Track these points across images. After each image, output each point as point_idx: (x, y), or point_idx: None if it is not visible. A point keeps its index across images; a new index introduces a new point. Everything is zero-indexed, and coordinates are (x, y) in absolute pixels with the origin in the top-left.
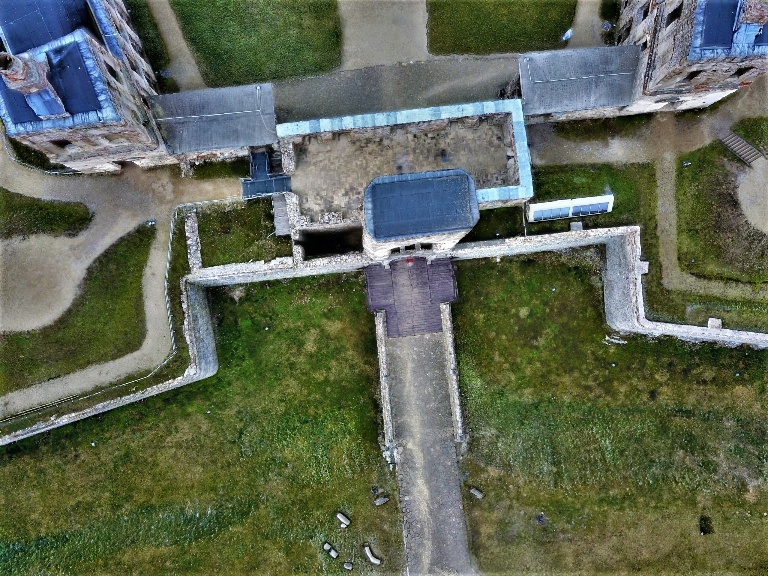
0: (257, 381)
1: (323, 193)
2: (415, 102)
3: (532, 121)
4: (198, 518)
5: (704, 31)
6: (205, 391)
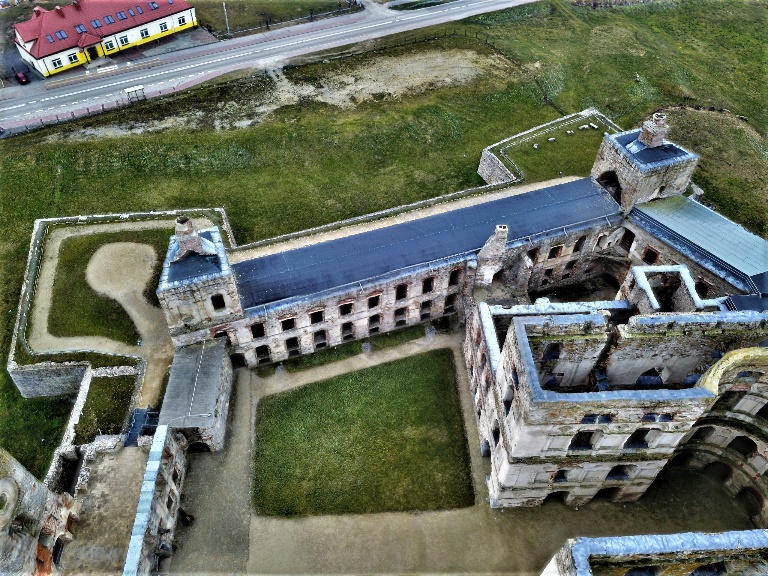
0: (2, 430)
1: (112, 474)
2: None
3: None
4: None
5: None
6: (11, 387)
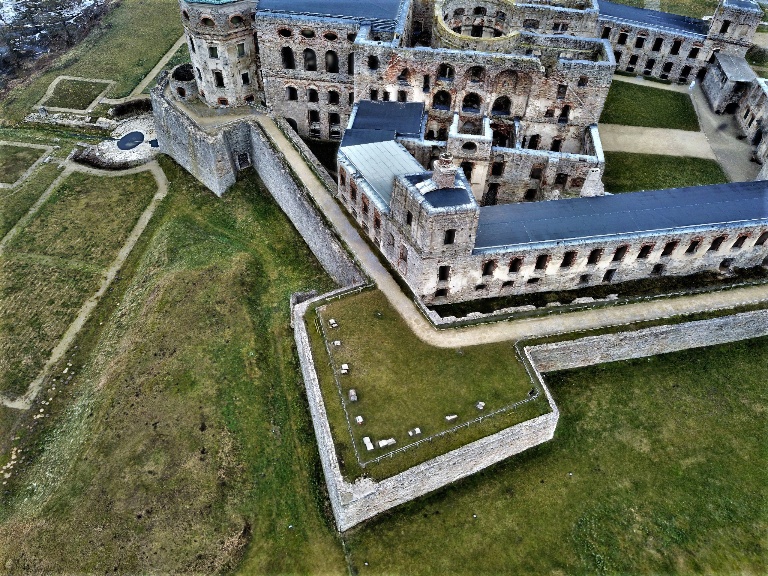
0: None
1: None
2: (730, 139)
3: None
4: None
5: (752, 8)
6: None
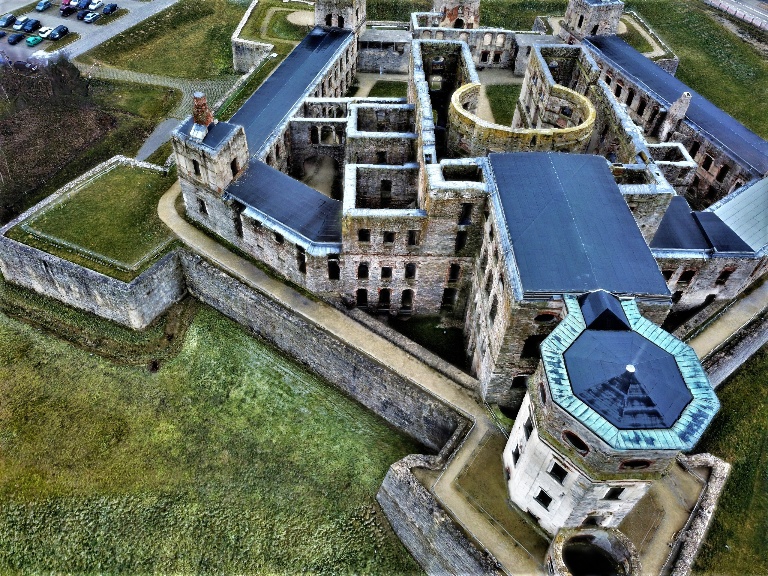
0: None
1: None
2: None
3: (402, 48)
4: (531, 7)
5: None
6: None
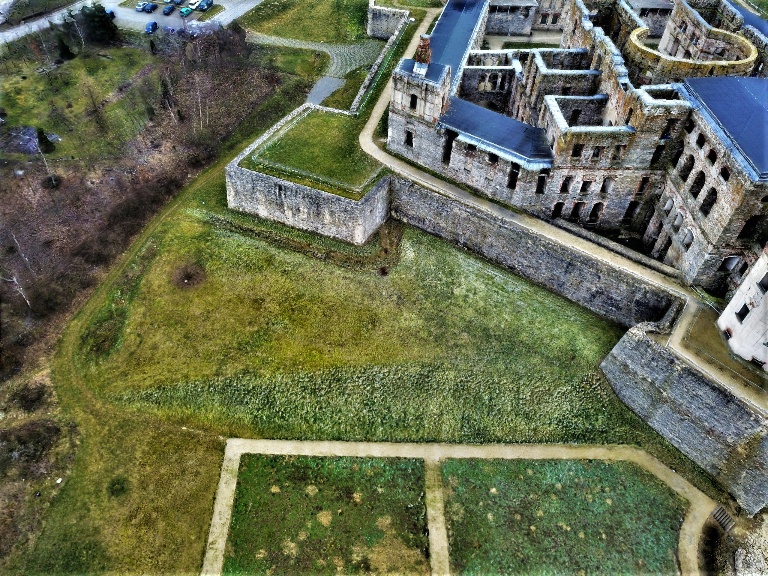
0: None
1: None
2: None
3: (524, 12)
4: None
5: None
6: None
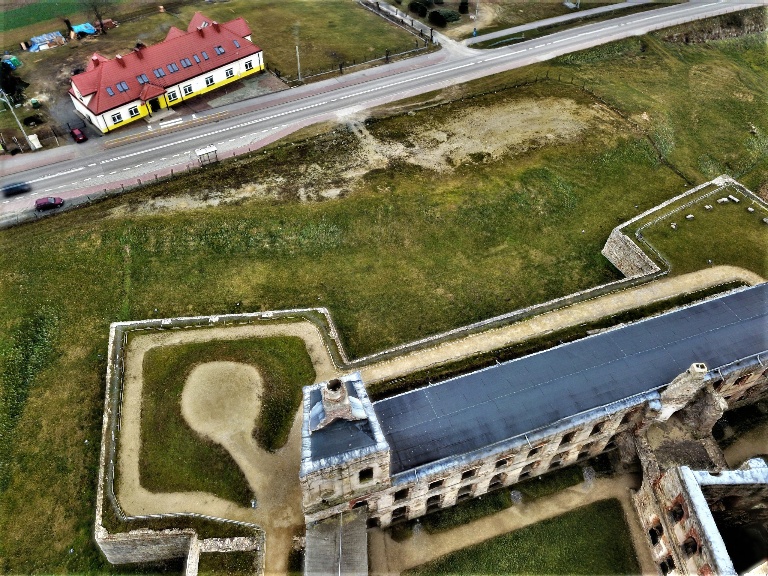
0: None
1: None
2: None
3: None
4: None
5: None
6: (95, 548)
